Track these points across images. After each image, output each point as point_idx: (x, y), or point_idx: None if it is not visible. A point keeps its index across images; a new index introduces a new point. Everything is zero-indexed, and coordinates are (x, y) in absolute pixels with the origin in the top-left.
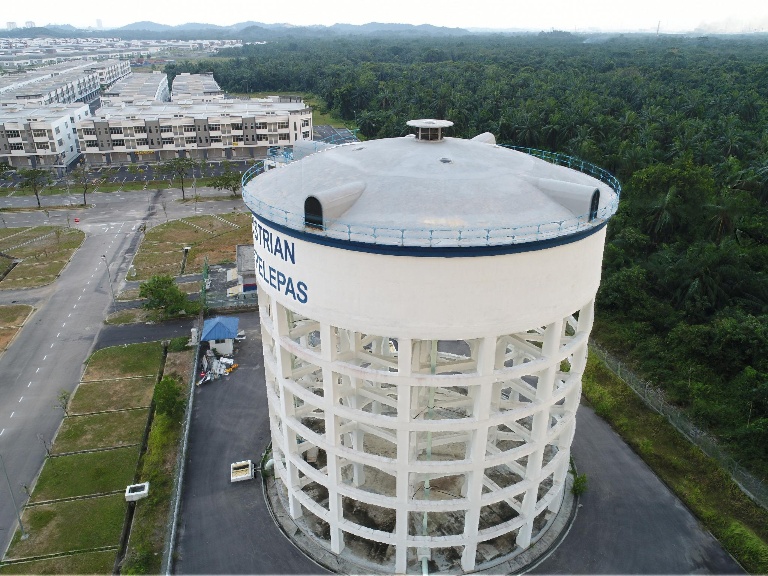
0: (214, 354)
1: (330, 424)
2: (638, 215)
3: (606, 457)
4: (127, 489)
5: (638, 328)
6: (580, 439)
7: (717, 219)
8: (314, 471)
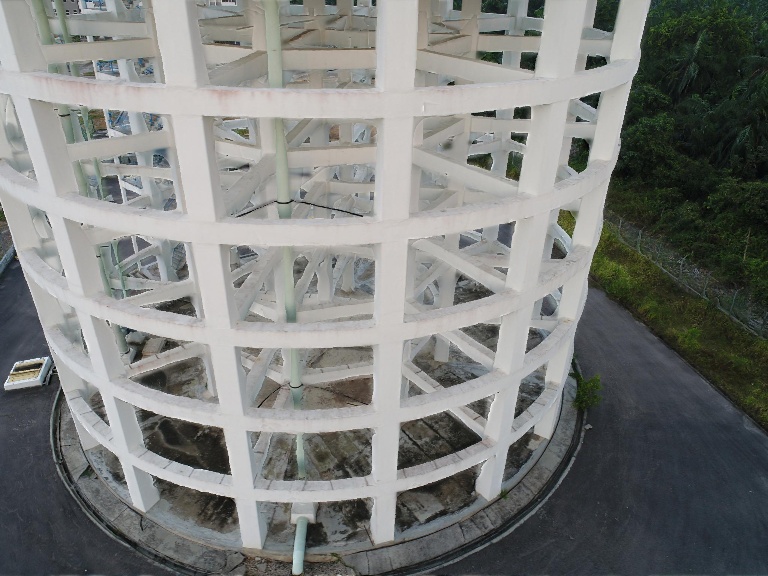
0: None
1: (63, 243)
2: (653, 83)
3: (627, 354)
4: None
5: (663, 195)
6: (585, 329)
7: (761, 73)
8: (76, 356)
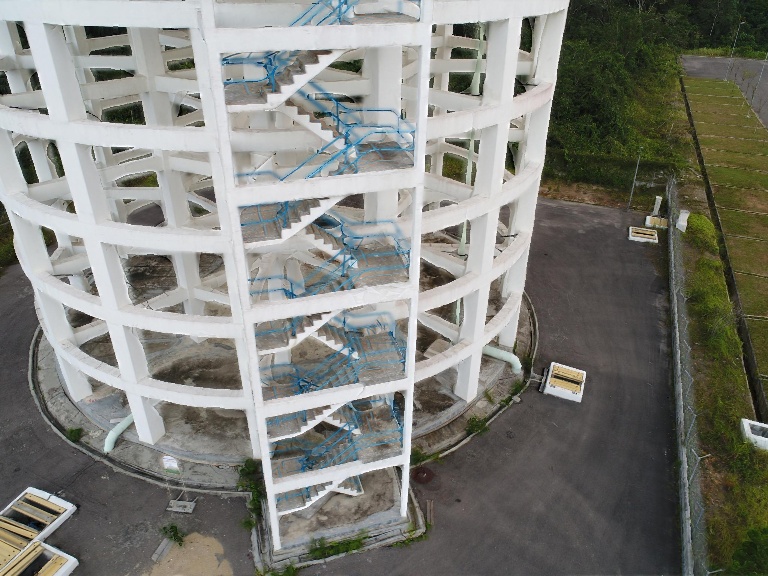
0: None
1: None
2: None
3: None
4: None
5: None
6: None
7: None
8: (506, 171)
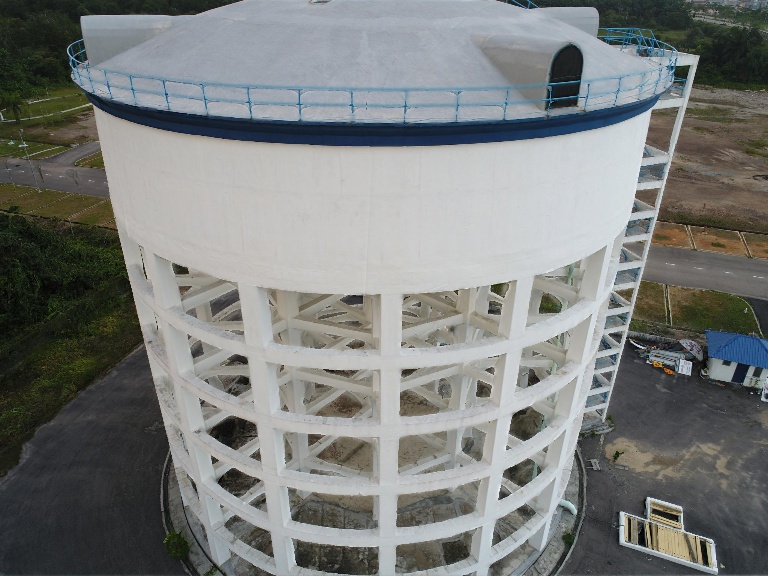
0: (704, 359)
1: None
2: None
3: None
4: None
5: None
6: None
7: None
8: None
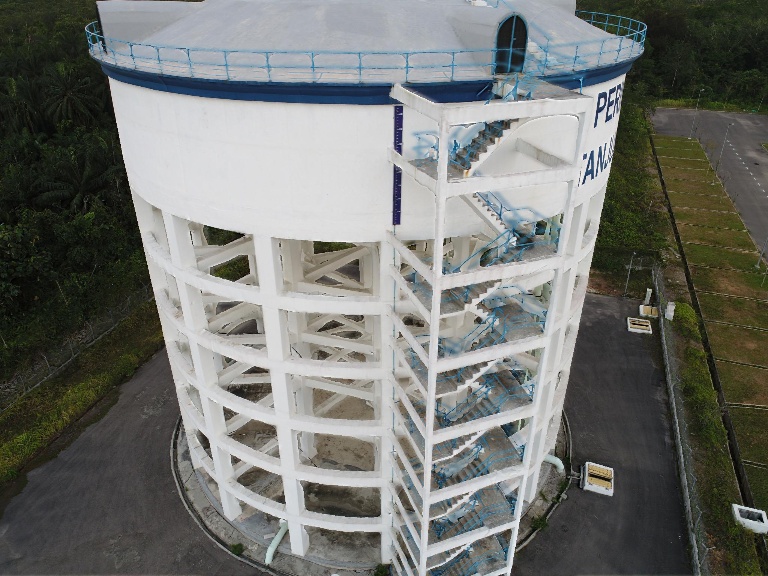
0: None
1: None
2: None
3: None
4: (767, 521)
5: None
6: None
7: None
8: None
